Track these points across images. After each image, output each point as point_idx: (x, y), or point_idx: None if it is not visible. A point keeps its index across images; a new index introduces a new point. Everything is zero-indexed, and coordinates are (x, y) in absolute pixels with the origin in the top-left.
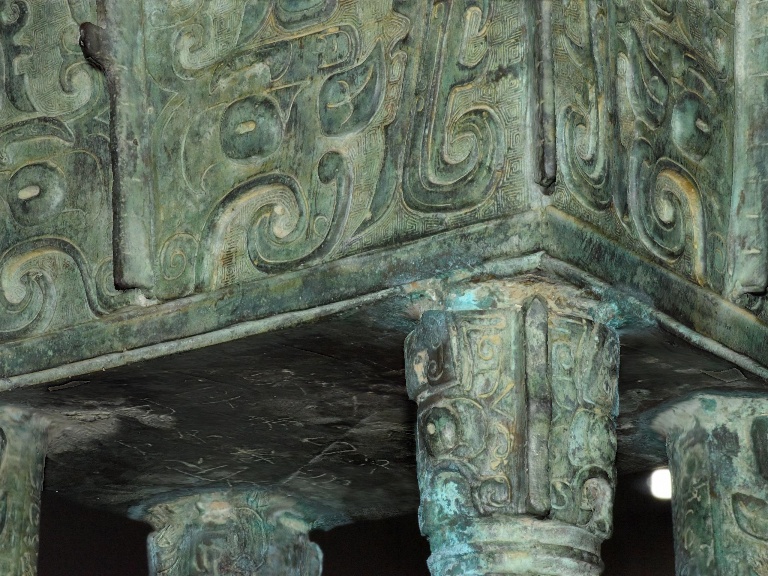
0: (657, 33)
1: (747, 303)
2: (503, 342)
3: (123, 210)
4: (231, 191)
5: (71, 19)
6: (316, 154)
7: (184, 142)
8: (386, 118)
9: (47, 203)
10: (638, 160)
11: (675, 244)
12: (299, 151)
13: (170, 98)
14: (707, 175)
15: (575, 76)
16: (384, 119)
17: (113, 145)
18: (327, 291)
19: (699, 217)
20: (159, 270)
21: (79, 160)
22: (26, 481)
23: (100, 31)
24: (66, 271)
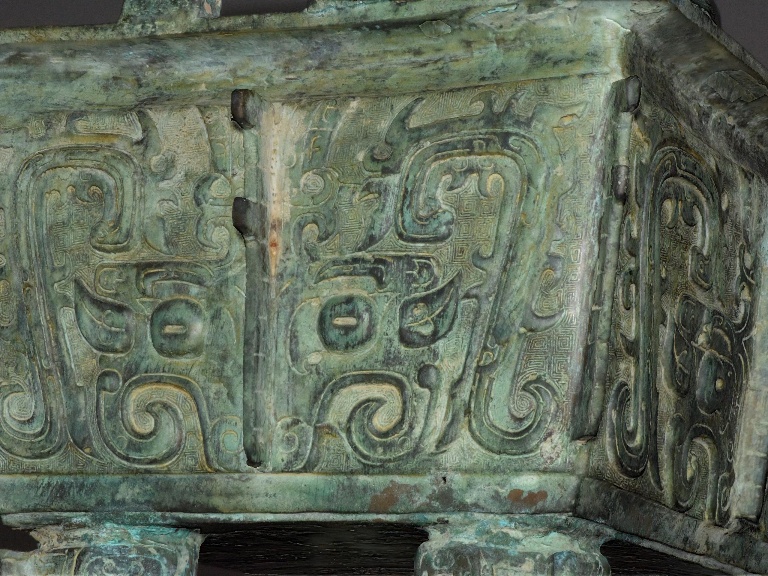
0: (111, 268)
1: (284, 467)
2: None
3: None
4: None
5: None
6: None
7: None
8: None
9: None
10: None
11: (163, 449)
12: None
13: None
14: (210, 366)
15: (7, 353)
16: None
17: None
18: None
19: None
20: None
21: None
22: None
23: None
24: None
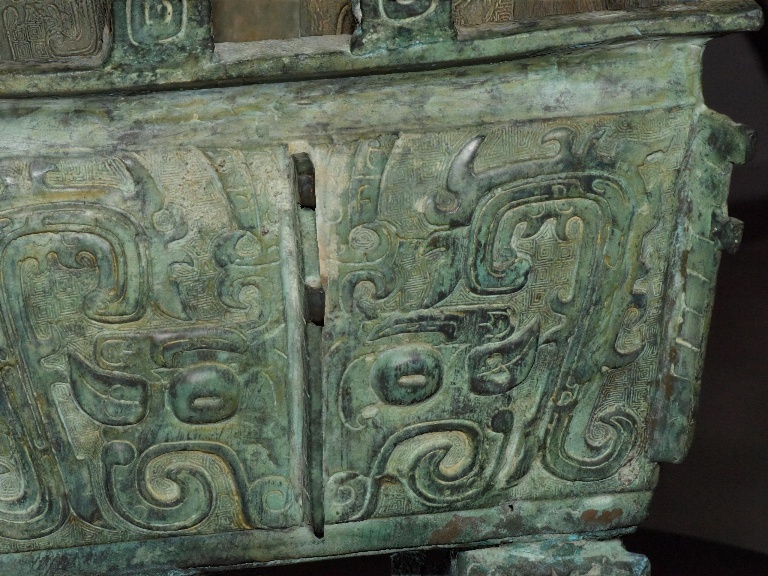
0: (116, 340)
1: (339, 518)
2: None
3: None
4: None
5: None
6: None
7: None
8: None
9: None
10: (106, 467)
11: (191, 514)
12: None
13: None
14: (244, 428)
15: None
16: None
17: None
18: None
19: (232, 474)
20: None
21: None
22: None
23: None
24: None
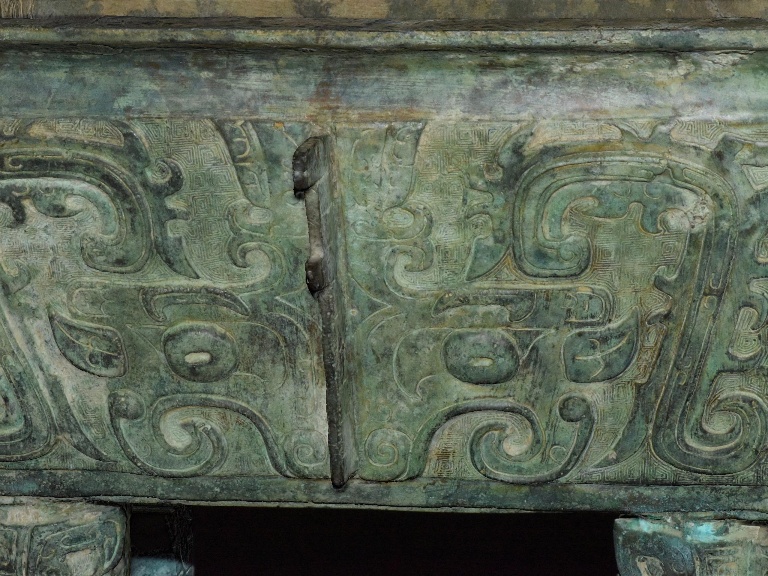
0: None
1: None
2: (740, 568)
3: (340, 419)
4: (456, 407)
5: (242, 196)
6: (557, 394)
7: (397, 350)
8: (638, 376)
9: (221, 370)
10: None
11: None
12: (537, 387)
13: (381, 308)
14: None
15: None
16: (635, 377)
17: (329, 360)
18: (557, 502)
19: None
20: (364, 456)
21: (256, 333)
22: (129, 527)
23: (322, 264)
24: (240, 428)
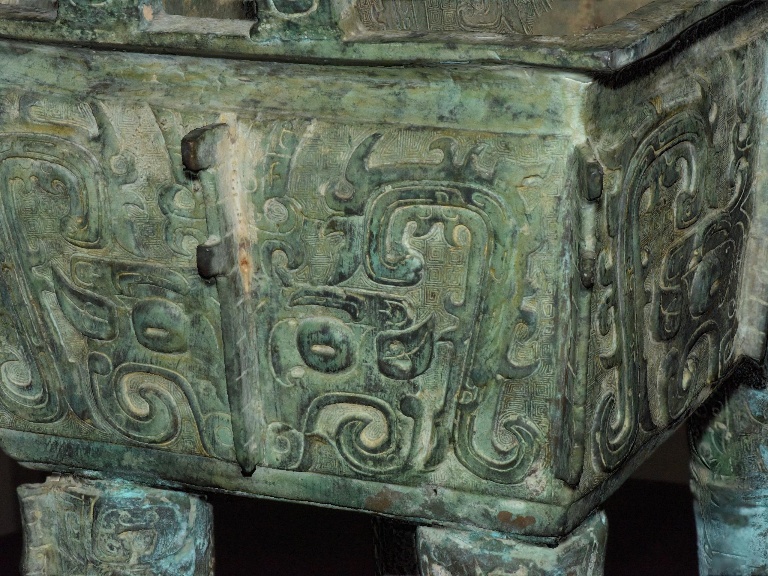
0: (86, 262)
1: (280, 465)
2: None
3: None
4: None
5: None
6: None
7: None
8: None
9: None
10: None
11: (160, 431)
12: None
13: None
14: (196, 364)
15: None
16: None
17: None
18: None
19: None
20: None
21: None
22: None
23: None
24: None
